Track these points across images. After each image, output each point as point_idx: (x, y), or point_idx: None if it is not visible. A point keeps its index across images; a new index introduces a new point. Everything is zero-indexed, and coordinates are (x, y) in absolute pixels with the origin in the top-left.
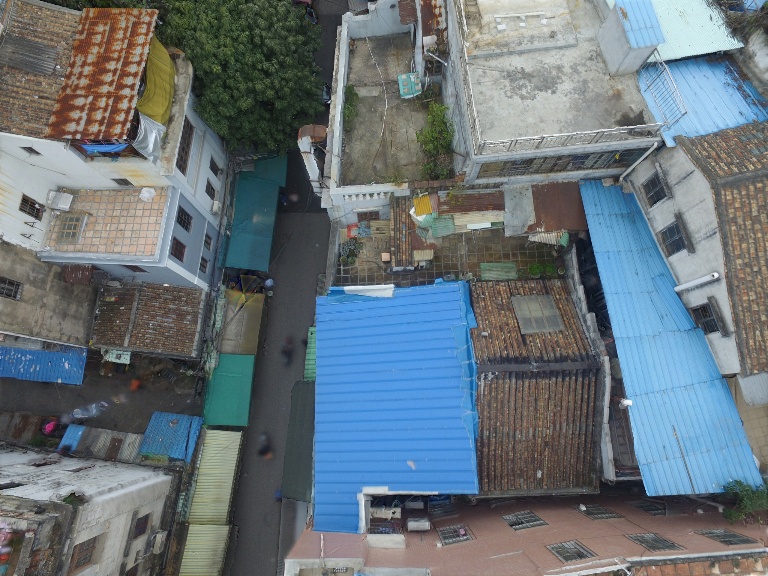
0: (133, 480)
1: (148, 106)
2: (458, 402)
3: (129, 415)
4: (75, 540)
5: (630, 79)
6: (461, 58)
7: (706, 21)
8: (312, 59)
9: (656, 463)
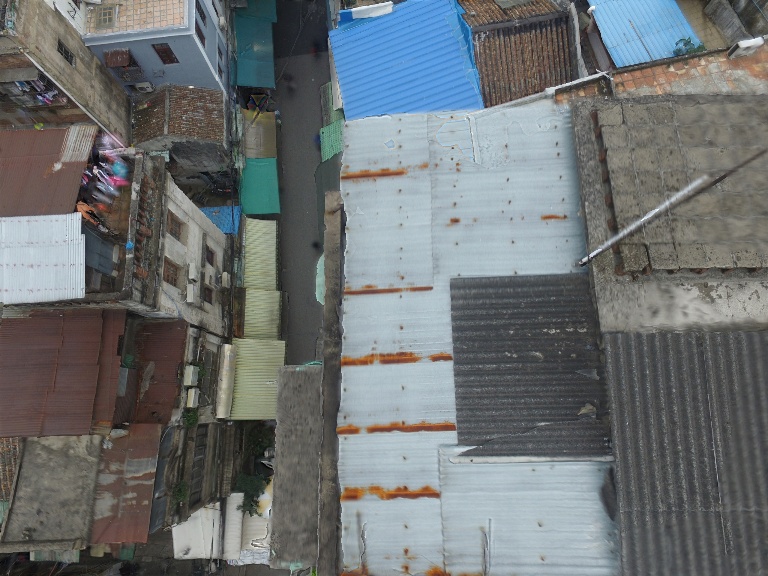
0: None
1: None
2: (460, 67)
3: None
4: (168, 202)
5: None
6: None
7: None
8: None
9: (620, 45)
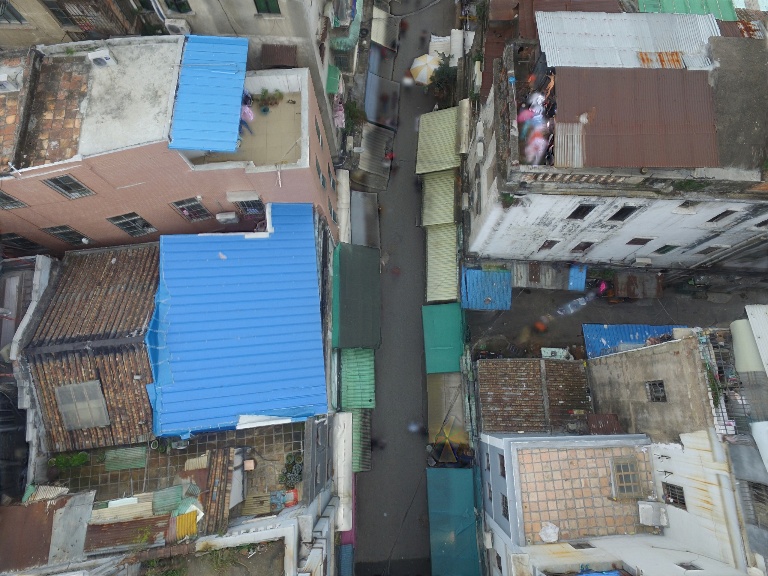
0: (491, 238)
1: None
2: (173, 310)
3: (543, 311)
4: None
5: None
6: None
7: None
8: None
9: None
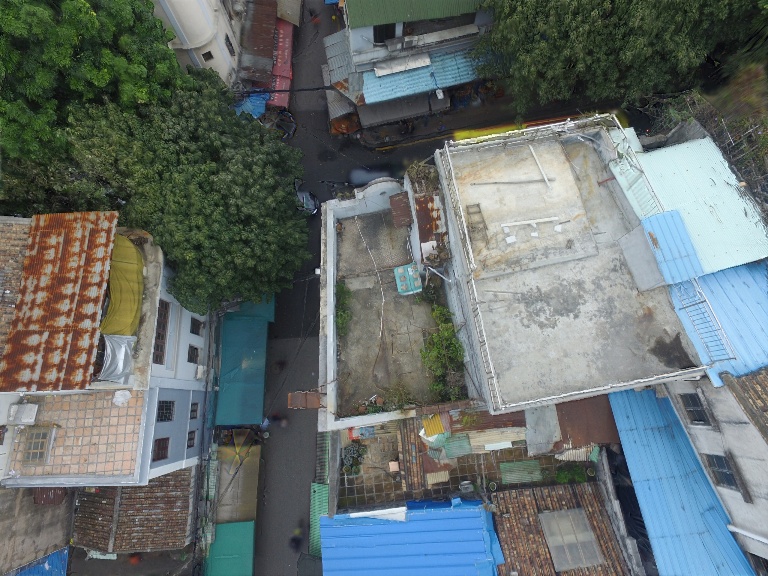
0: None
1: (114, 321)
2: None
3: None
4: None
5: (661, 293)
6: (468, 283)
7: (741, 218)
8: (294, 194)
9: None
